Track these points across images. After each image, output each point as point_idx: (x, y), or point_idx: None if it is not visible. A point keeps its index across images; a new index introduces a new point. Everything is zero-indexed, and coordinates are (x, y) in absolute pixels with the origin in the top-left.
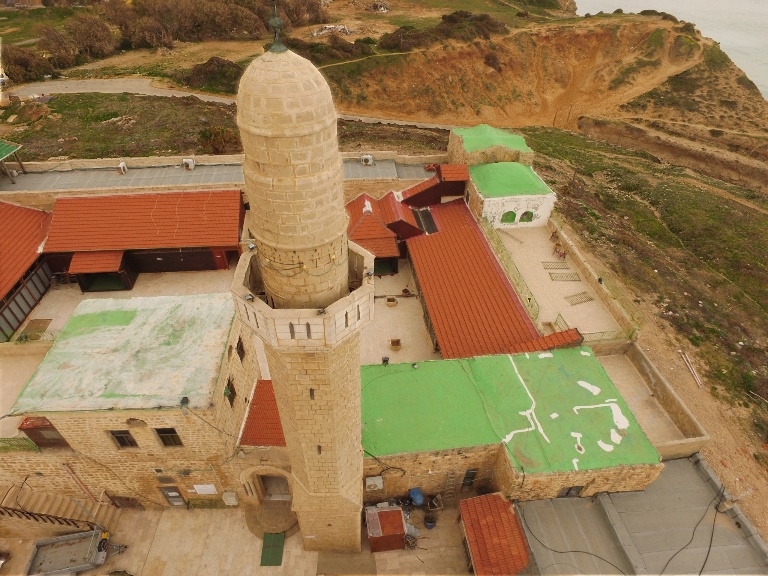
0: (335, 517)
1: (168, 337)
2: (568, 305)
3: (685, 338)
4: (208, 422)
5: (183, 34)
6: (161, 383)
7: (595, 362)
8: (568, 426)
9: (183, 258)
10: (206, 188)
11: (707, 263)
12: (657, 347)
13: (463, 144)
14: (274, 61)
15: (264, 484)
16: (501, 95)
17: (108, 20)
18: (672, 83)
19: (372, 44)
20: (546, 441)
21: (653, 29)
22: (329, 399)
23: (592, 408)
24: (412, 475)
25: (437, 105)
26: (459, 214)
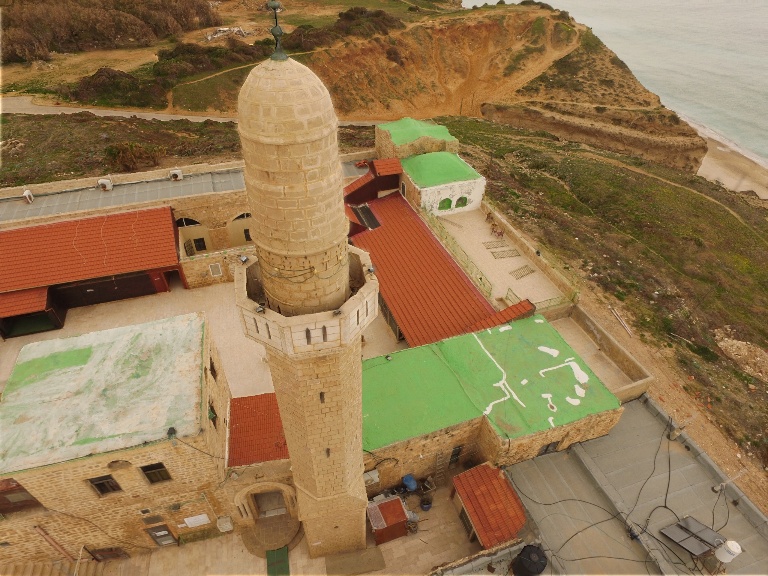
0: (342, 518)
1: (135, 369)
2: (514, 279)
3: (612, 295)
4: (199, 449)
5: (60, 45)
6: (140, 418)
7: (549, 327)
8: (538, 389)
9: (117, 286)
10: (132, 208)
11: (615, 226)
12: (590, 307)
13: (391, 138)
14: (279, 69)
15: (257, 503)
16: (407, 88)
17: None
18: (558, 67)
19: (272, 45)
20: (522, 406)
21: (534, 18)
22: (339, 400)
23: (555, 369)
24: (404, 463)
25: (347, 102)
26: (398, 207)
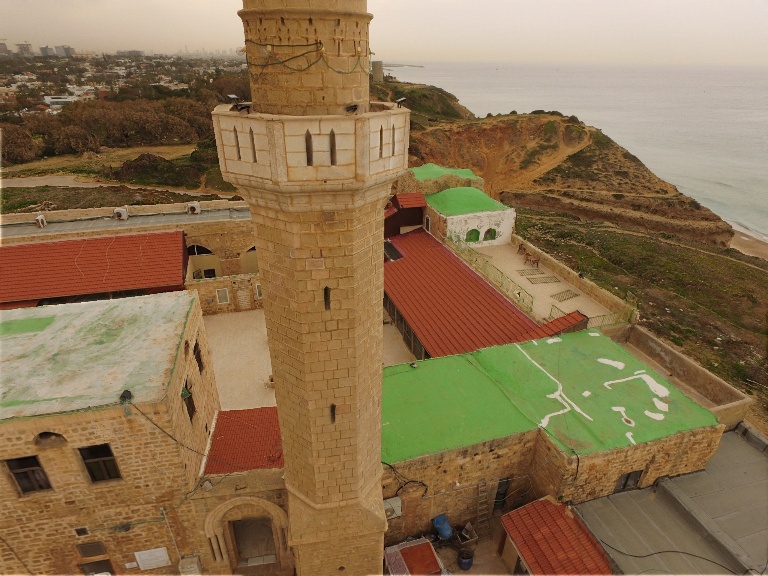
0: (350, 550)
1: (100, 336)
2: (556, 302)
3: (667, 340)
4: (161, 427)
5: (111, 141)
6: (90, 382)
7: (607, 340)
8: (606, 401)
9: None
10: (142, 231)
11: (655, 284)
12: None
13: (415, 176)
14: None
15: (237, 544)
16: None
17: (30, 130)
18: (572, 160)
19: None
20: (588, 419)
21: (545, 122)
22: (351, 307)
23: (623, 381)
24: (435, 493)
25: None
26: (422, 240)
